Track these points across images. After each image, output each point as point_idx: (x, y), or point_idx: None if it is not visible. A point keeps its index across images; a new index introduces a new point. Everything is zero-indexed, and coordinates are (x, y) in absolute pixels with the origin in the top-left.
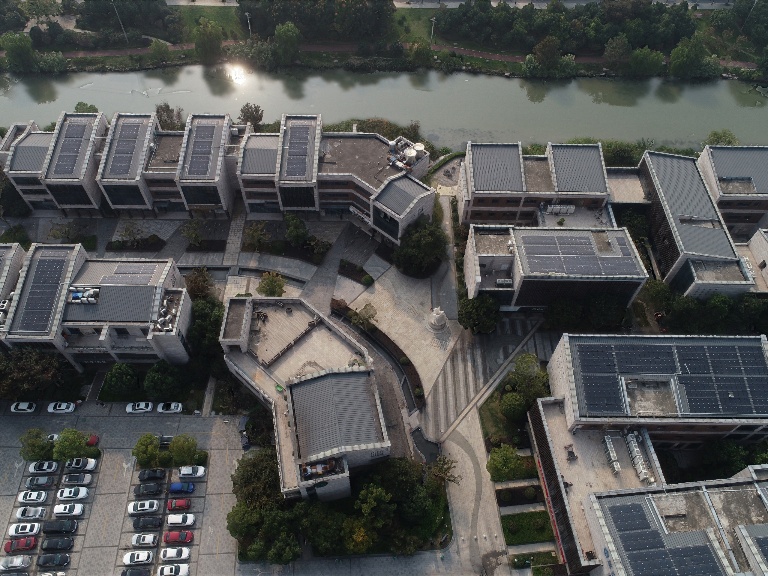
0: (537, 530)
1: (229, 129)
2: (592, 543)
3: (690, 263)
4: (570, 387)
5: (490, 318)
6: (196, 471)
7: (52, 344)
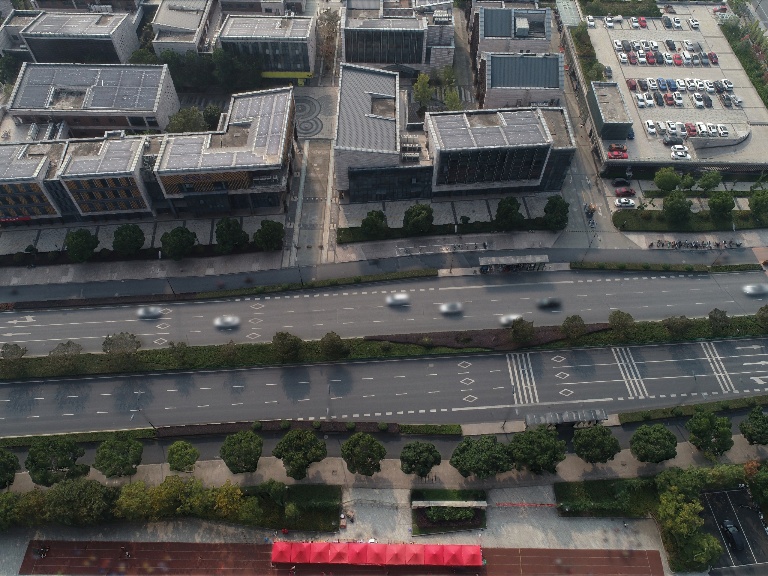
0: None
1: None
2: None
3: (157, 31)
4: None
5: (11, 71)
6: None
7: None
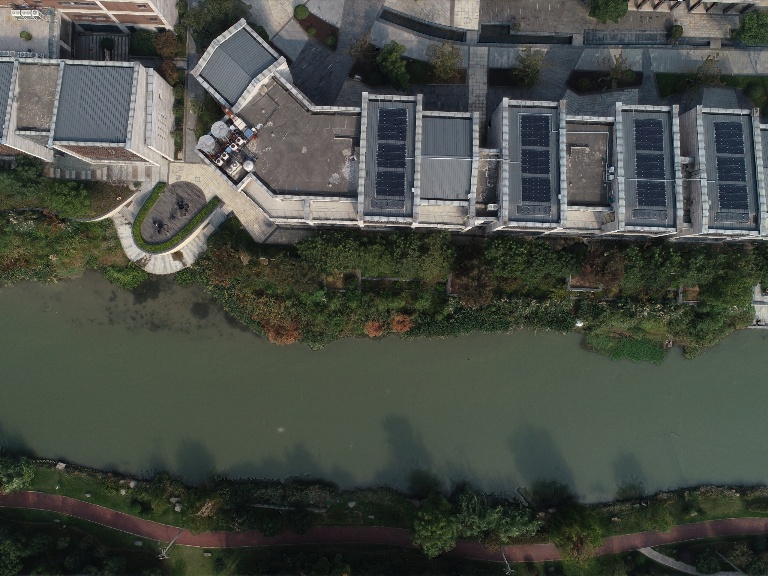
0: None
1: None
2: None
3: None
4: None
5: None
6: None
7: None
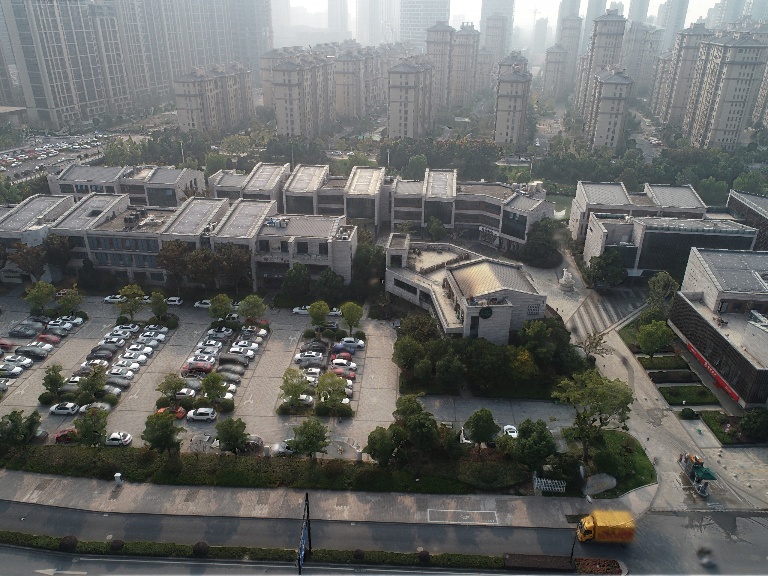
0: (699, 395)
1: (384, 176)
2: (762, 367)
3: None
4: (707, 273)
5: (618, 267)
6: (357, 341)
7: (247, 248)
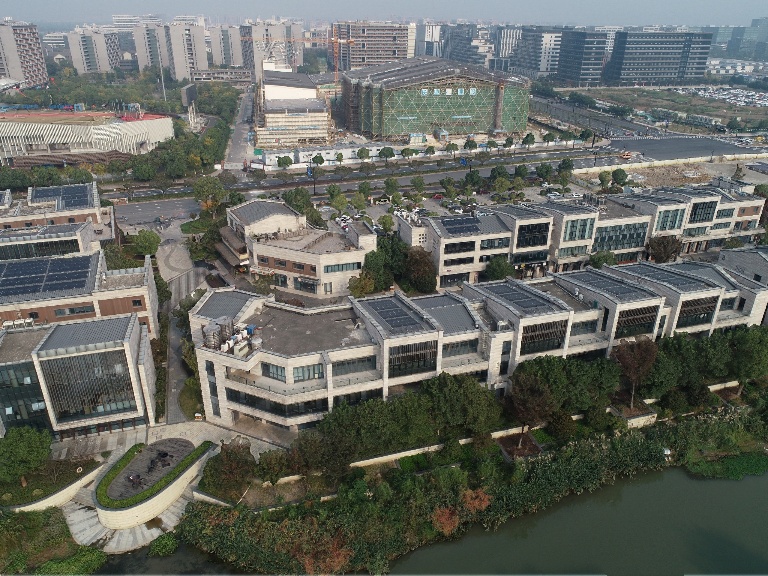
0: None
1: (509, 320)
2: None
3: None
4: None
5: None
6: None
7: None
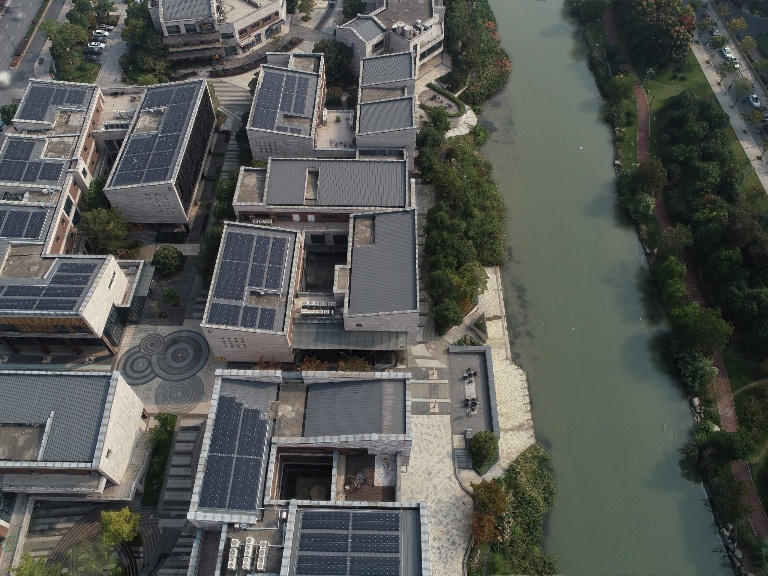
0: None
1: None
2: None
3: None
4: None
5: None
6: None
7: None
